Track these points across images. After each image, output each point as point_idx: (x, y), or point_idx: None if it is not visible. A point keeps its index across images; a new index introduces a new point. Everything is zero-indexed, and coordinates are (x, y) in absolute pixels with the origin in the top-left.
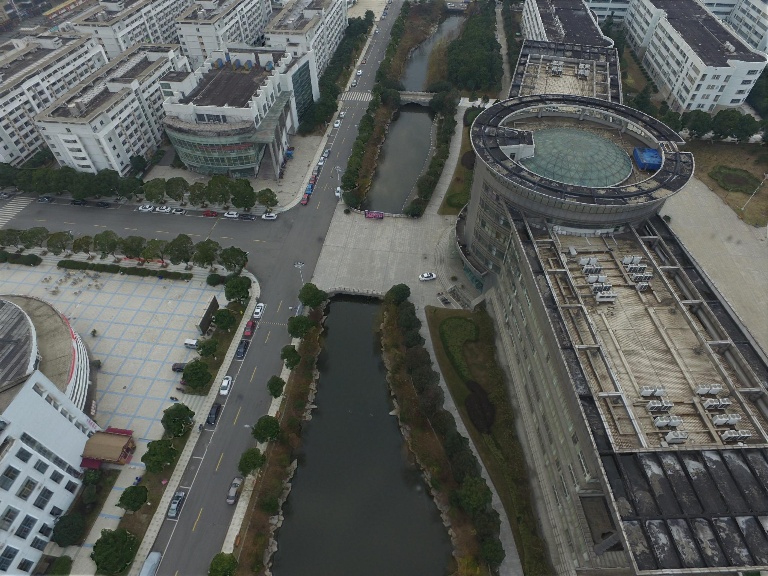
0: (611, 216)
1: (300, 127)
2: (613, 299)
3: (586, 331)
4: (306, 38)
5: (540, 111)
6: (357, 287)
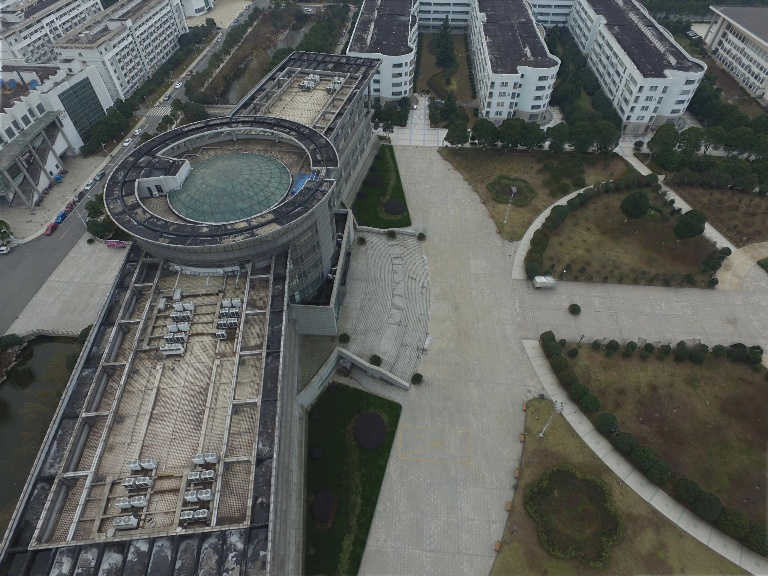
0: (222, 255)
1: (81, 148)
2: (179, 351)
3: (130, 391)
4: (100, 52)
5: (233, 134)
6: (60, 327)
